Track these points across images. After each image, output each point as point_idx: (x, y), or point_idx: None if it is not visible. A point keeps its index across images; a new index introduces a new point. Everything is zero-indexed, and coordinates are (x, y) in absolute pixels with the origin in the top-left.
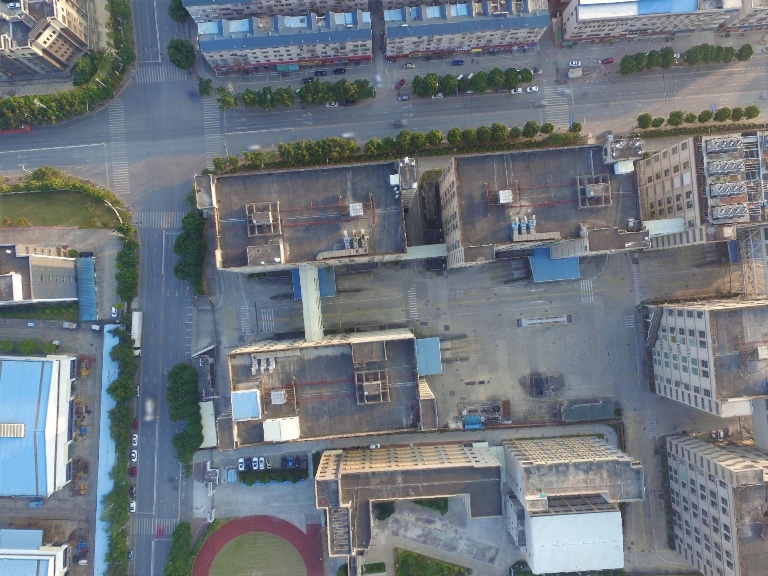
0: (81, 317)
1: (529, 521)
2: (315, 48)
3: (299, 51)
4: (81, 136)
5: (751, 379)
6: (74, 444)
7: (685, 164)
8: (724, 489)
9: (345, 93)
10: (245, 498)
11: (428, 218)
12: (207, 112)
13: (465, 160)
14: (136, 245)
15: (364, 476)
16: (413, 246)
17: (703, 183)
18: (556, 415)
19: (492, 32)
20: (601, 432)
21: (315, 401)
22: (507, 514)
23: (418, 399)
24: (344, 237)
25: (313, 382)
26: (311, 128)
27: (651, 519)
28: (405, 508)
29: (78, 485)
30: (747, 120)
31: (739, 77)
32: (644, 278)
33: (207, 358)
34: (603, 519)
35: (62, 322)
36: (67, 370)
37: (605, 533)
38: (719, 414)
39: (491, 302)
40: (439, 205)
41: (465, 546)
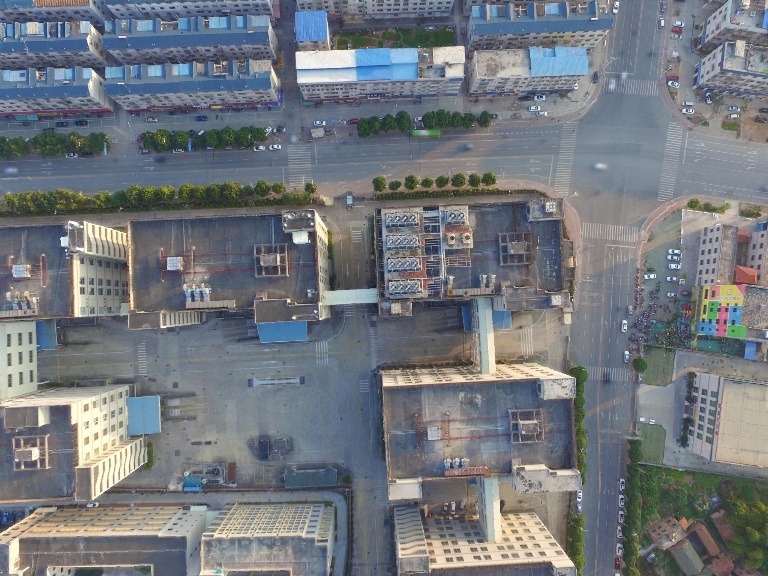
0: None
1: None
2: (38, 102)
3: (25, 104)
4: None
5: (428, 460)
6: None
7: None
8: None
9: (74, 146)
10: None
11: None
12: None
13: (143, 224)
14: None
15: (45, 541)
16: None
17: (380, 257)
18: (283, 480)
19: (216, 92)
20: (330, 499)
21: None
22: None
23: None
24: None
25: None
26: (50, 178)
27: None
28: (121, 571)
29: None
30: (493, 185)
31: (487, 142)
32: (381, 342)
33: None
34: None
35: None
36: None
37: None
38: None
39: (223, 360)
40: None
41: None
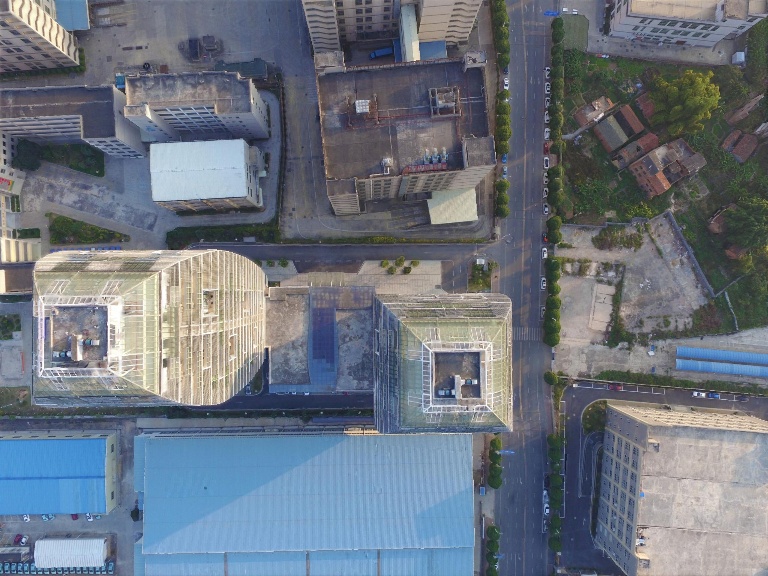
0: None
1: None
2: None
3: None
4: None
5: None
6: None
7: None
8: None
9: None
10: None
11: None
12: None
13: None
14: None
15: None
16: None
17: None
18: None
19: None
20: (262, 98)
21: None
22: None
23: None
24: None
25: None
26: None
27: (313, 185)
28: (60, 173)
29: None
30: None
31: None
32: None
33: None
34: (224, 146)
35: None
36: None
37: (226, 160)
38: None
39: None
40: None
41: (123, 213)
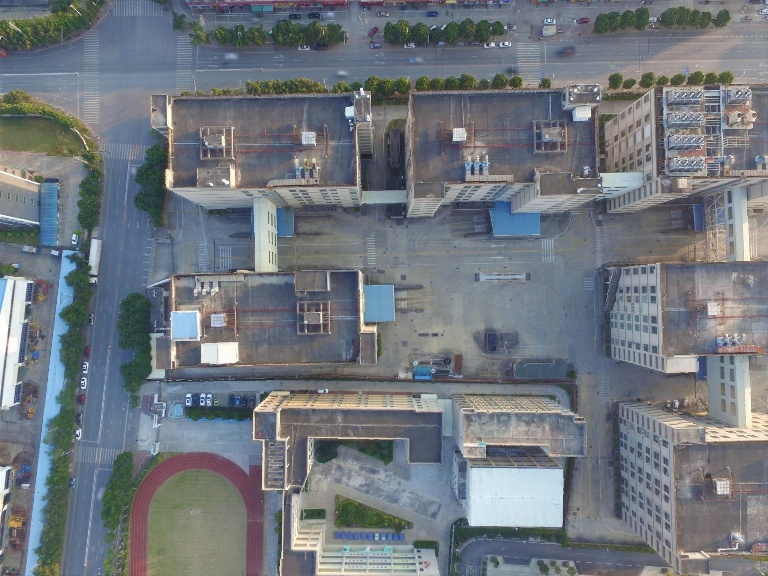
0: (41, 241)
1: (469, 472)
2: None
3: None
4: (55, 64)
5: (700, 337)
6: (26, 367)
7: (646, 117)
8: (666, 448)
9: (316, 35)
10: (190, 434)
11: (391, 166)
12: (180, 48)
13: (422, 98)
14: (100, 174)
15: (304, 413)
16: (373, 191)
17: (661, 134)
18: (508, 373)
19: None
20: (553, 394)
21: (256, 328)
22: (452, 470)
23: (359, 333)
24: (296, 166)
25: (255, 309)
26: (282, 70)
27: (599, 486)
28: (349, 456)
29: (26, 408)
30: None
31: (716, 45)
32: (607, 241)
33: (161, 290)
34: (544, 475)
35: (23, 246)
36: (23, 292)
37: (545, 490)
38: (664, 369)
39: (450, 255)
40: (403, 153)
41: (408, 499)
